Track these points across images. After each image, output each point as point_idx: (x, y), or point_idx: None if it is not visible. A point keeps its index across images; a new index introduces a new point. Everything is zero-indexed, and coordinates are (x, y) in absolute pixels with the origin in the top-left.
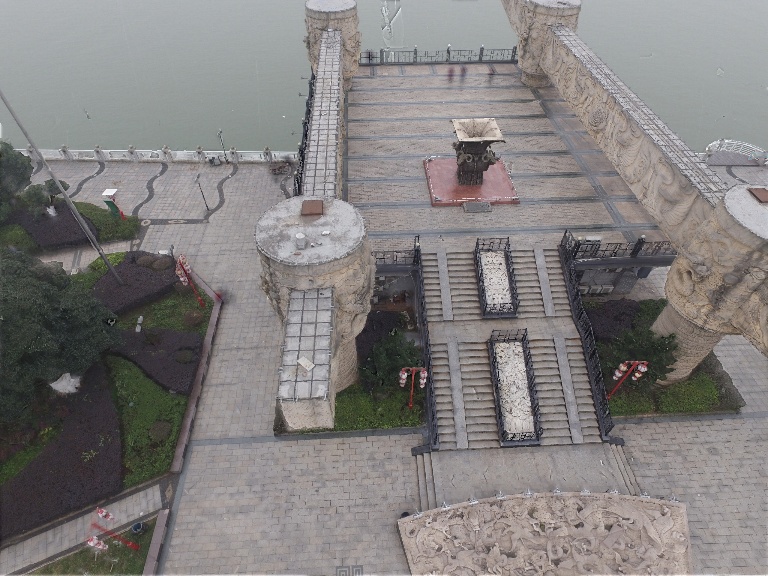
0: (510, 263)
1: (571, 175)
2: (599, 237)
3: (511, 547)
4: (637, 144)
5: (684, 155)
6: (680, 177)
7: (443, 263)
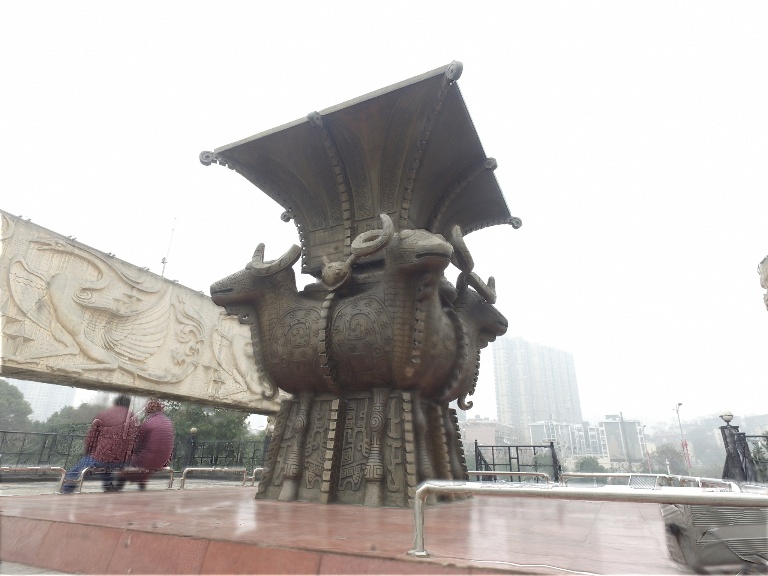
0: None
1: None
2: None
3: None
4: (162, 304)
5: None
6: None
7: None
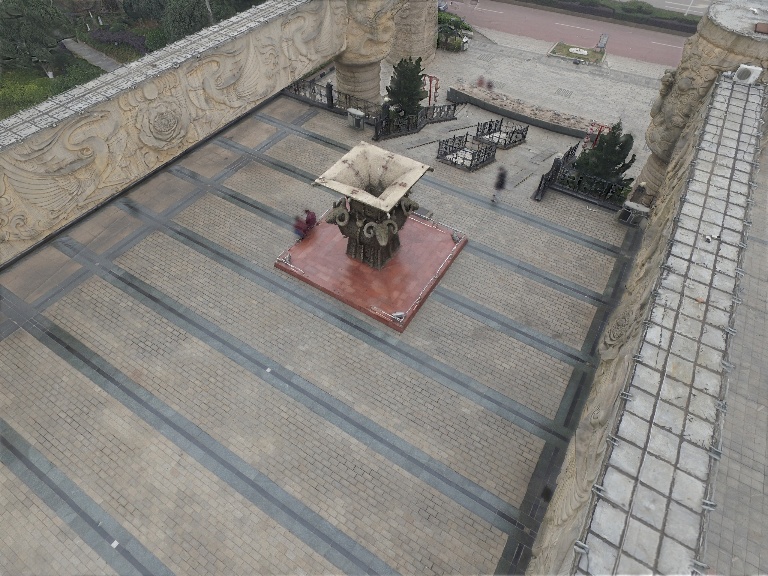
0: (442, 154)
1: (231, 194)
2: (351, 110)
3: (555, 115)
4: (251, 52)
5: (271, 7)
6: (309, 7)
7: (512, 182)
